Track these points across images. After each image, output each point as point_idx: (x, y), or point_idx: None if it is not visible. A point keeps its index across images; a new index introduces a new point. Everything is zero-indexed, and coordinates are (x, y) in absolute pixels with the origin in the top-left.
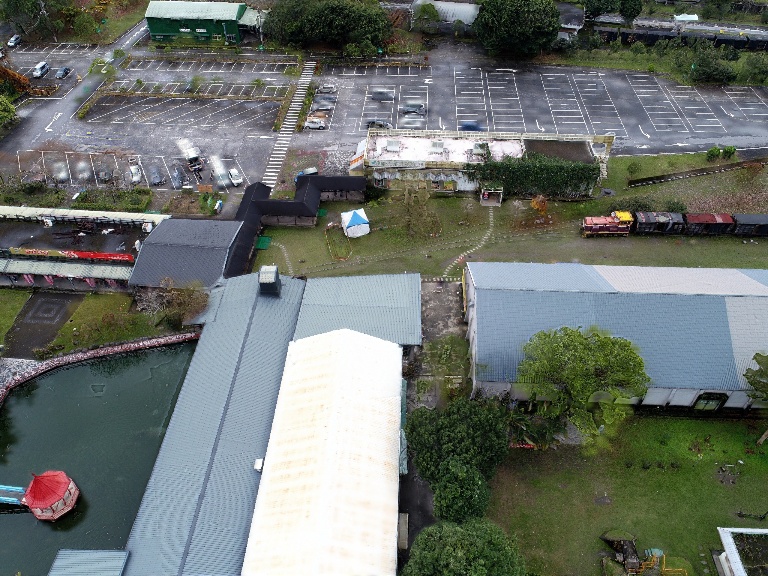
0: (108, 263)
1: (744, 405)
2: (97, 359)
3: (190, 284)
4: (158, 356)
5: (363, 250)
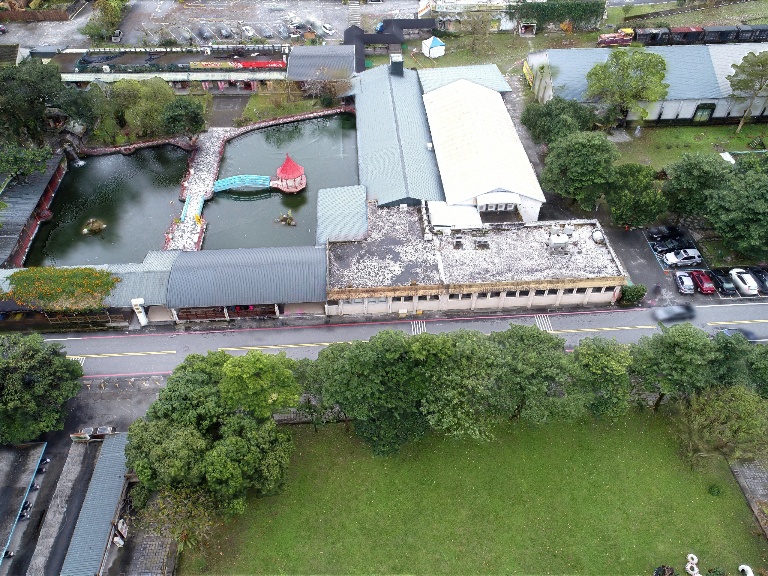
0: (266, 70)
1: (725, 114)
2: (277, 127)
3: (333, 78)
4: (310, 136)
5: (443, 64)
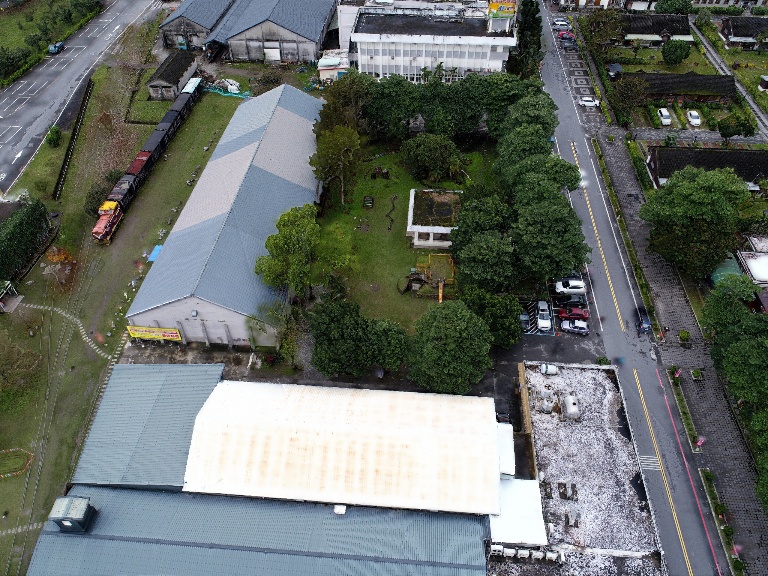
0: None
1: (318, 201)
2: None
3: None
4: None
5: (23, 437)
